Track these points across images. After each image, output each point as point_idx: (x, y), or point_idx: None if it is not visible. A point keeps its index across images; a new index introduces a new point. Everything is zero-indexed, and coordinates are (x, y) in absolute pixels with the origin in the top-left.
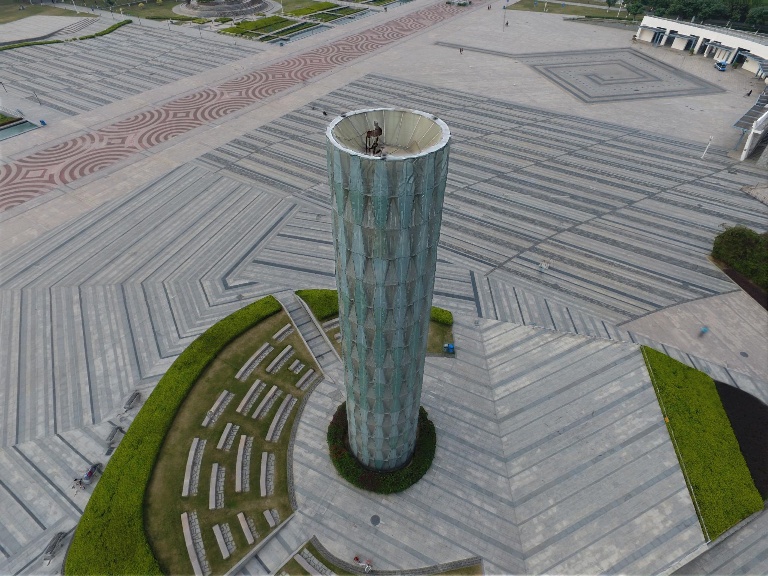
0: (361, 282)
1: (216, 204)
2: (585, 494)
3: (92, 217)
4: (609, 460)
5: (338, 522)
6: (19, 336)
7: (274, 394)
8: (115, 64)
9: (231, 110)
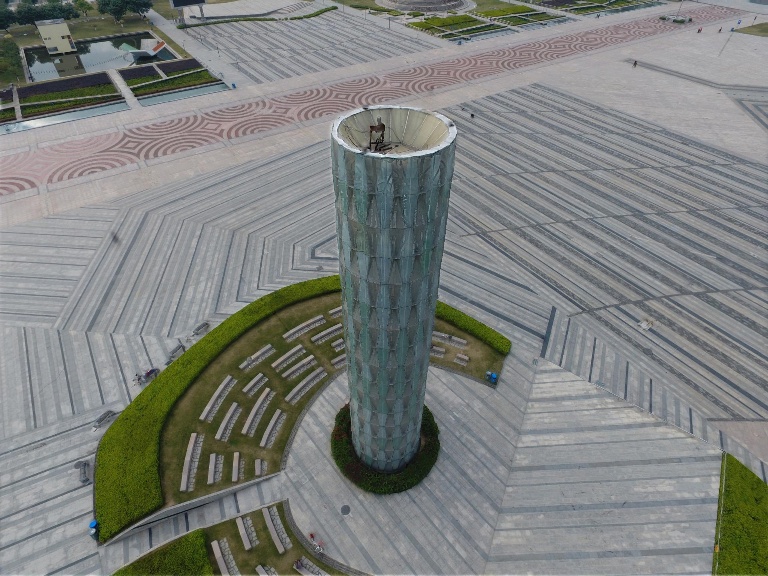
0: (349, 272)
1: None
2: None
3: (236, 170)
4: (619, 561)
5: (313, 496)
6: (148, 252)
7: (309, 362)
8: (308, 44)
9: (386, 99)
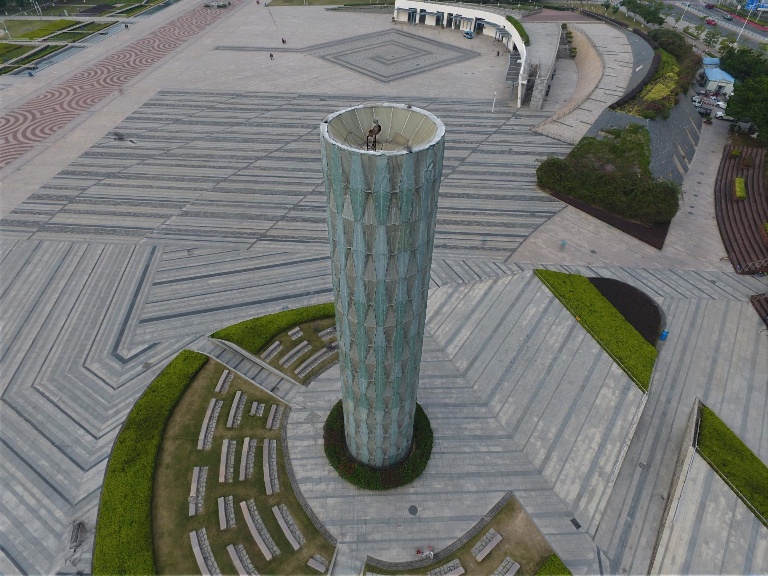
0: (383, 282)
1: (52, 275)
2: (555, 401)
3: None
4: (557, 367)
5: (382, 531)
6: None
7: (249, 446)
8: None
9: (5, 162)
